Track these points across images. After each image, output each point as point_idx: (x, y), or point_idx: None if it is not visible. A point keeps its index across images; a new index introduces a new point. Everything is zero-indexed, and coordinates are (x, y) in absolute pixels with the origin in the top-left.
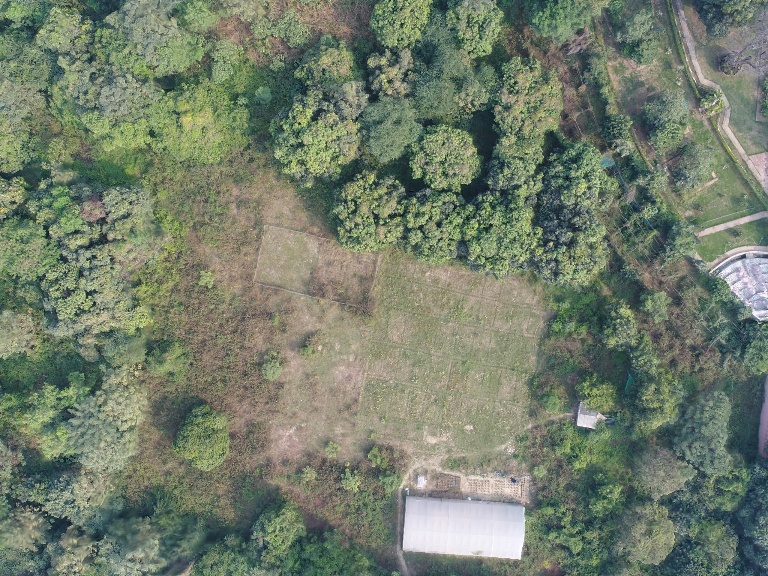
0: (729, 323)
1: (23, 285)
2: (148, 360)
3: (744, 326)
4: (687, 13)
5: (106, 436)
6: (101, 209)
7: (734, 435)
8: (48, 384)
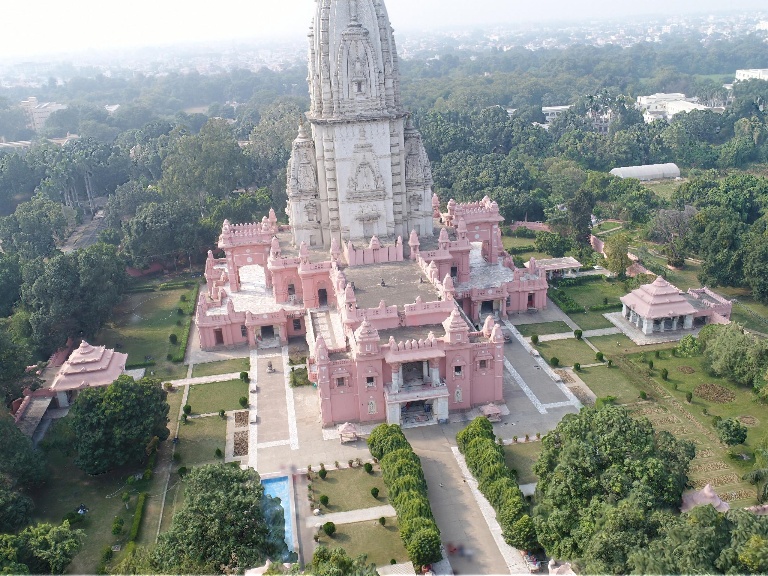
0: None
1: None
2: None
3: None
4: None
5: None
6: None
7: None
8: None
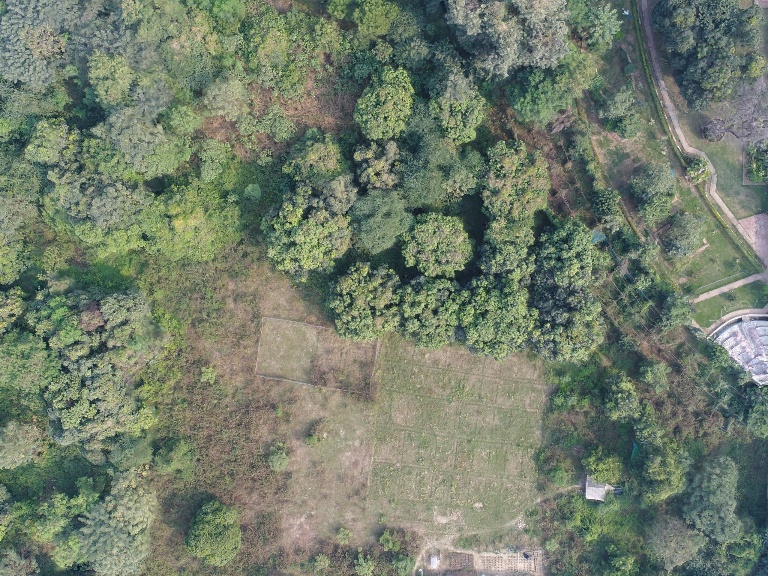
0: (730, 387)
1: (26, 395)
2: (155, 460)
3: (745, 390)
4: (667, 83)
5: (118, 542)
6: (99, 318)
7: (743, 497)
8: (57, 488)
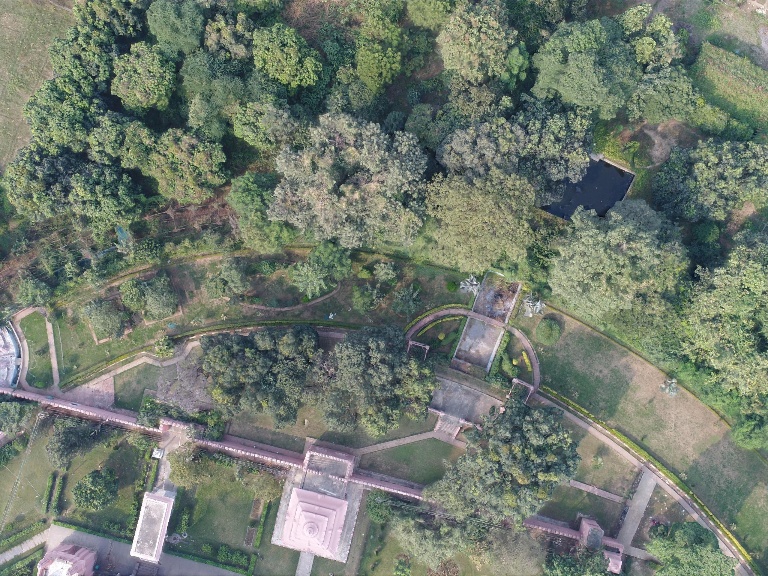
0: None
1: None
2: None
3: None
4: None
5: None
6: None
7: None
8: None
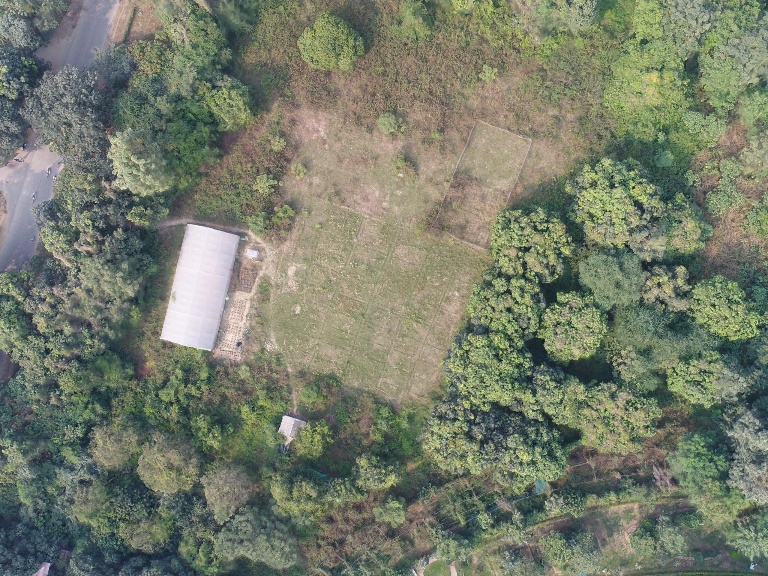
0: None
1: None
2: (419, 1)
3: None
4: None
5: None
6: None
7: (249, 568)
8: None
